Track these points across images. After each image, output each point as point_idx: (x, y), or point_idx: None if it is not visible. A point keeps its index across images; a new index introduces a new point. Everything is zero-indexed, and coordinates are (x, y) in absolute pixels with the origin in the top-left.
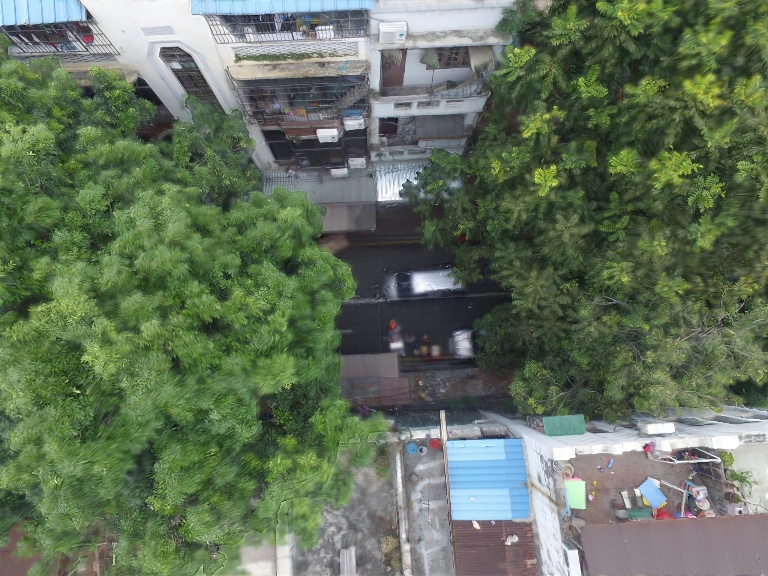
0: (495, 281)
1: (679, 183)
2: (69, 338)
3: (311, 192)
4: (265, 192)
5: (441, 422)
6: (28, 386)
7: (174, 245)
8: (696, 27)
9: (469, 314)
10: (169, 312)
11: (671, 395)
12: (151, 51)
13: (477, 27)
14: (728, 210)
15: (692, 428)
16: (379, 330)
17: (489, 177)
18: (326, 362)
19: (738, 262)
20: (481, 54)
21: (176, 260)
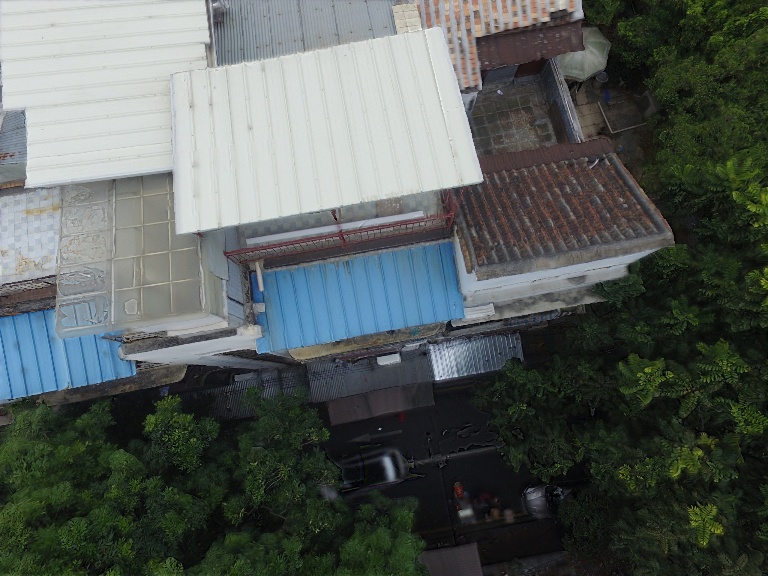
0: None
1: None
2: None
3: (362, 380)
4: (313, 387)
5: None
6: None
7: None
8: None
9: None
10: None
11: None
12: None
13: (569, 288)
14: None
15: None
16: (443, 492)
17: None
18: None
19: None
20: None
21: None
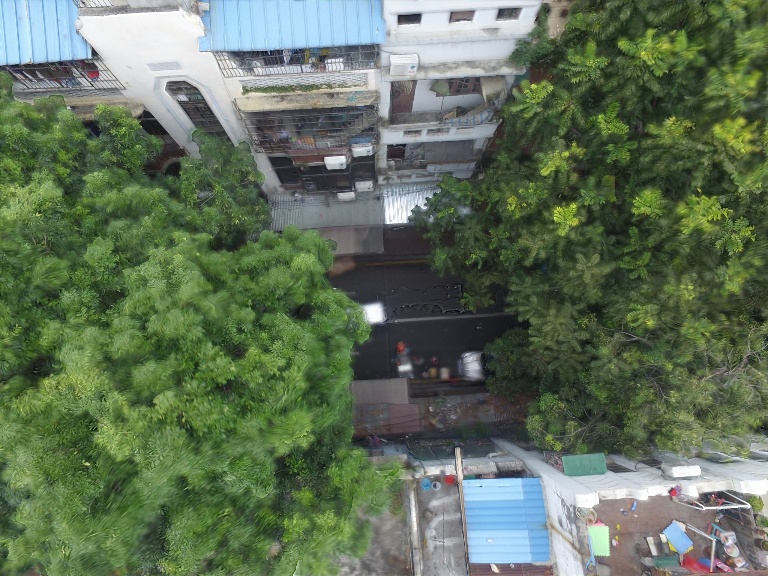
0: (504, 301)
1: (708, 228)
2: (78, 408)
3: (318, 216)
4: None
5: (456, 460)
6: (35, 464)
7: (186, 307)
8: (723, 67)
9: (478, 335)
10: (182, 378)
11: (697, 438)
12: (157, 85)
13: (490, 57)
14: (755, 249)
15: (717, 468)
16: (387, 352)
17: (505, 212)
18: (339, 403)
19: (765, 301)
20: (493, 83)
21: (189, 323)
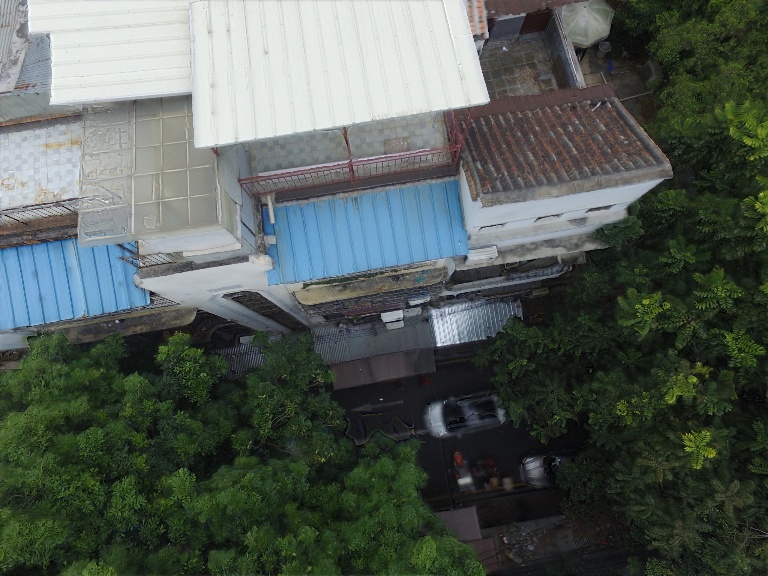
0: None
1: None
2: None
3: (365, 345)
4: (317, 351)
5: None
6: None
7: None
8: None
9: None
10: None
11: None
12: (214, 297)
13: (570, 234)
14: None
15: None
16: (443, 462)
17: None
18: None
19: None
20: None
21: None
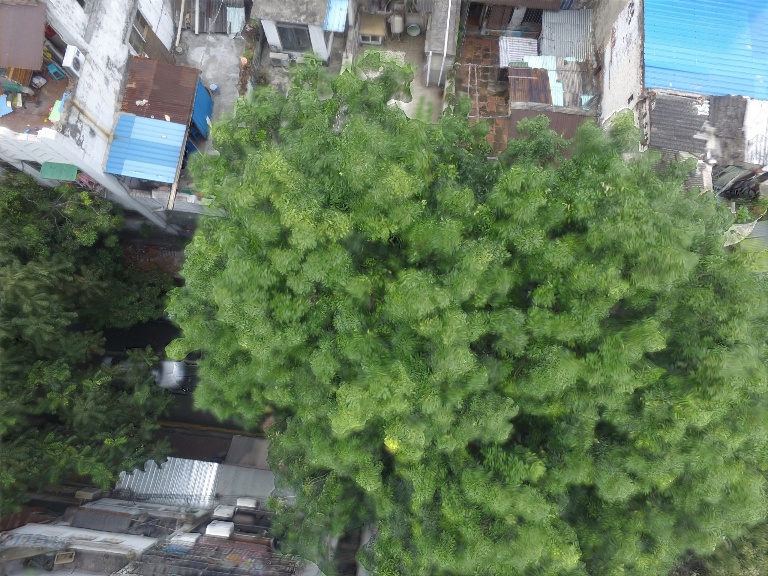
0: None
1: None
2: None
3: None
4: None
5: None
6: None
7: (229, 284)
8: None
9: None
10: None
11: None
12: None
13: None
14: None
15: None
16: None
17: (6, 395)
18: None
19: None
20: None
21: None
